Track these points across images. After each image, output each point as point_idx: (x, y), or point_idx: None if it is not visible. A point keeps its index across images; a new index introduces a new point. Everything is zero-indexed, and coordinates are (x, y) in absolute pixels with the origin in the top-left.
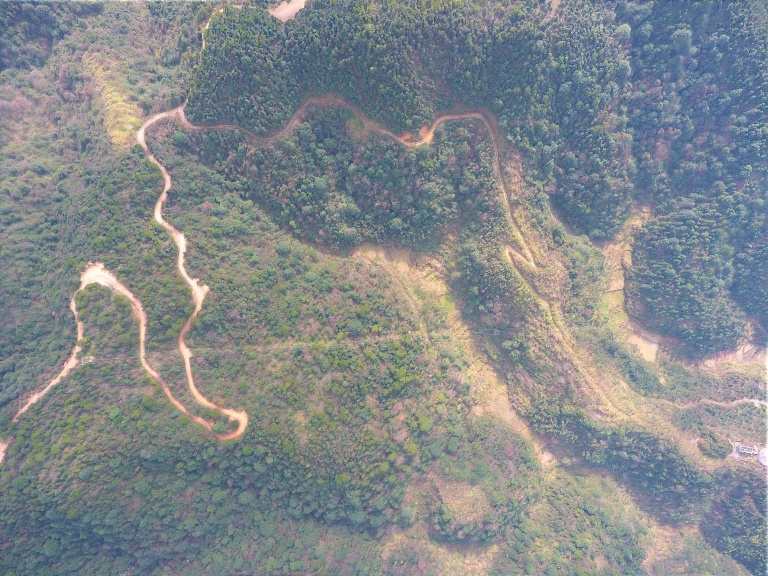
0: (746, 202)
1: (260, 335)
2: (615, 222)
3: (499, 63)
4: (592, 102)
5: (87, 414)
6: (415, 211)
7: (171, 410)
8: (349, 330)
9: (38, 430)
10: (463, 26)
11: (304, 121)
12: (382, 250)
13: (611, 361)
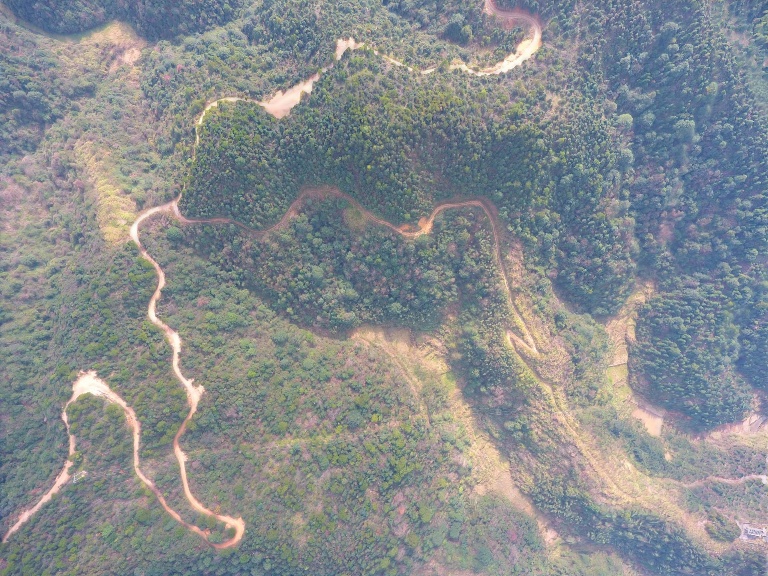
0: (752, 284)
1: (257, 432)
2: (618, 300)
3: (499, 157)
4: (594, 191)
5: (79, 533)
6: (414, 296)
7: (166, 522)
8: (348, 423)
9: (29, 554)
10: (462, 124)
11: (300, 212)
12: (381, 331)
13: (615, 442)
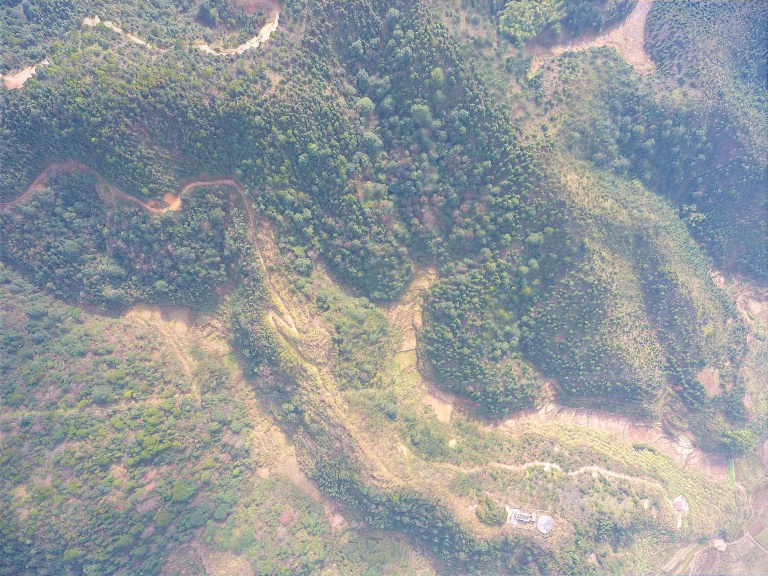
0: (510, 270)
1: None
2: (395, 284)
3: (231, 135)
4: (338, 172)
5: None
6: (178, 274)
7: None
8: (93, 397)
9: None
10: (184, 100)
11: (48, 186)
12: (158, 310)
13: (389, 425)
